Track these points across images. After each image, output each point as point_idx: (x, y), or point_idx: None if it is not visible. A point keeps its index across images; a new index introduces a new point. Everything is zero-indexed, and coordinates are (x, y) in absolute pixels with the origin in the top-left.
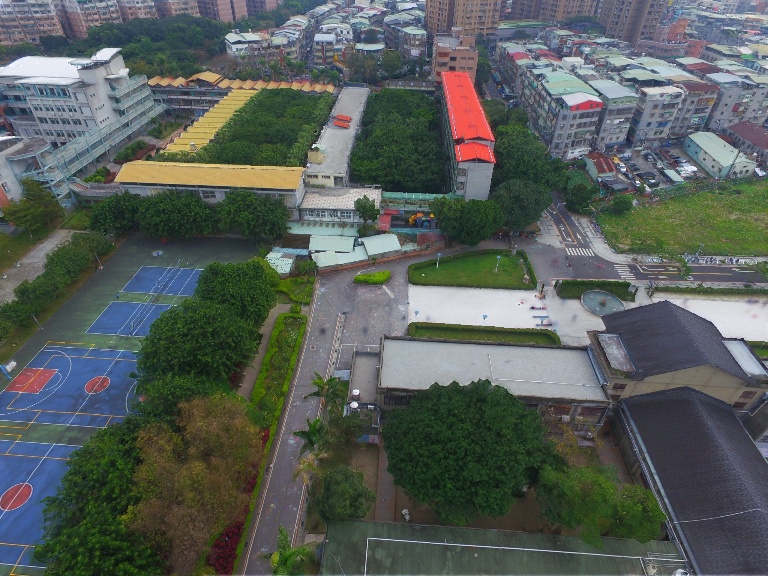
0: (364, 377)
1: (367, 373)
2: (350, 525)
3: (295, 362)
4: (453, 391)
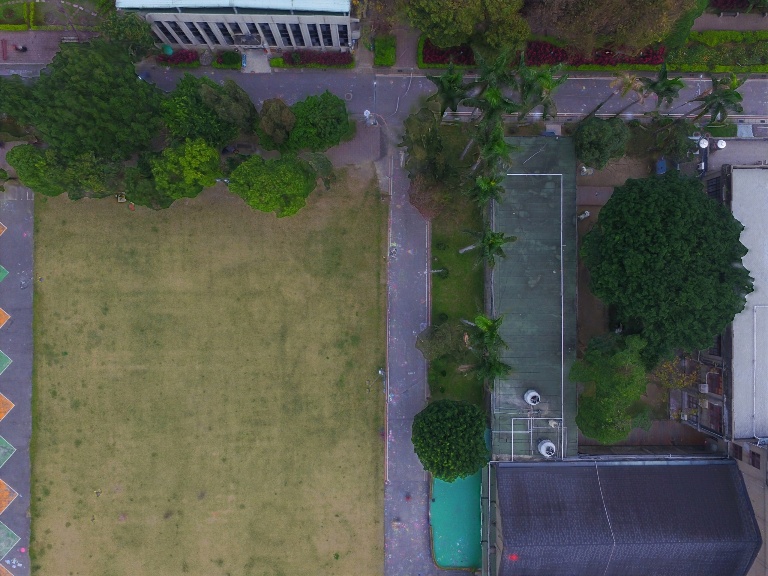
0: (745, 155)
1: (751, 158)
2: (572, 157)
3: (761, 72)
4: (733, 247)
